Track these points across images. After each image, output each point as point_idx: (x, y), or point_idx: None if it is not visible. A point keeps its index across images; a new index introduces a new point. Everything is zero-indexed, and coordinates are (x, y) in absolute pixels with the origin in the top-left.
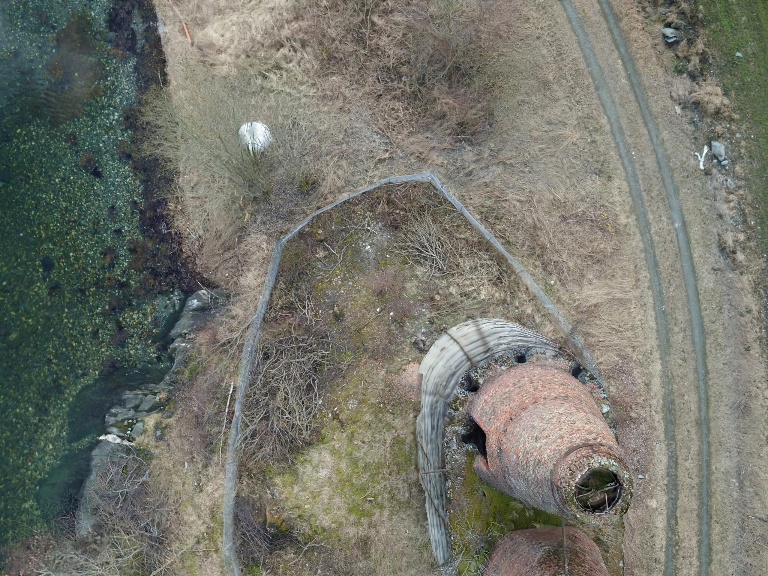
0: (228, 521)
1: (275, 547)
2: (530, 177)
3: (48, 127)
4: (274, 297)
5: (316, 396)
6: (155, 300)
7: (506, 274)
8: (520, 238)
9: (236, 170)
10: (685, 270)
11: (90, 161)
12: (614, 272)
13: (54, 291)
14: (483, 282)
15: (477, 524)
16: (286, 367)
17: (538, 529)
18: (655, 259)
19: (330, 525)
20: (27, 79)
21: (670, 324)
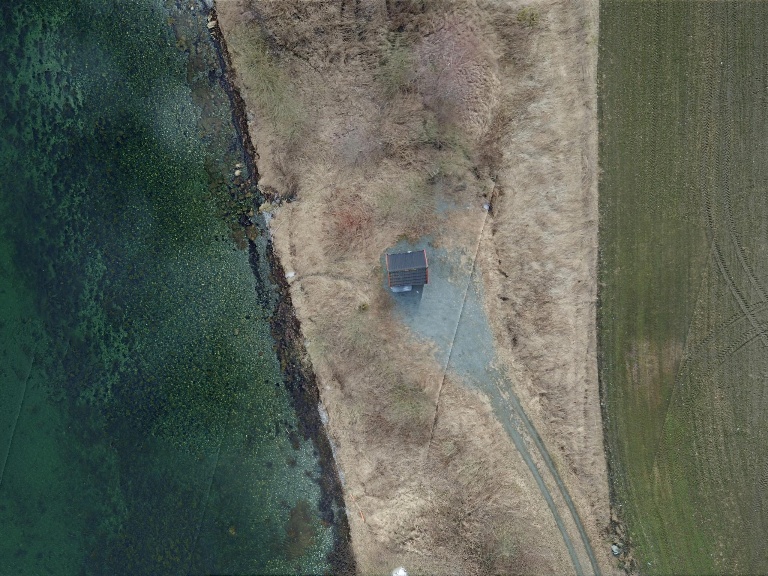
0: None
1: None
2: None
3: (285, 560)
4: None
5: None
6: None
7: None
8: None
9: None
10: None
11: None
12: None
13: None
14: None
15: None
16: None
17: None
18: None
19: None
20: (274, 533)
21: None
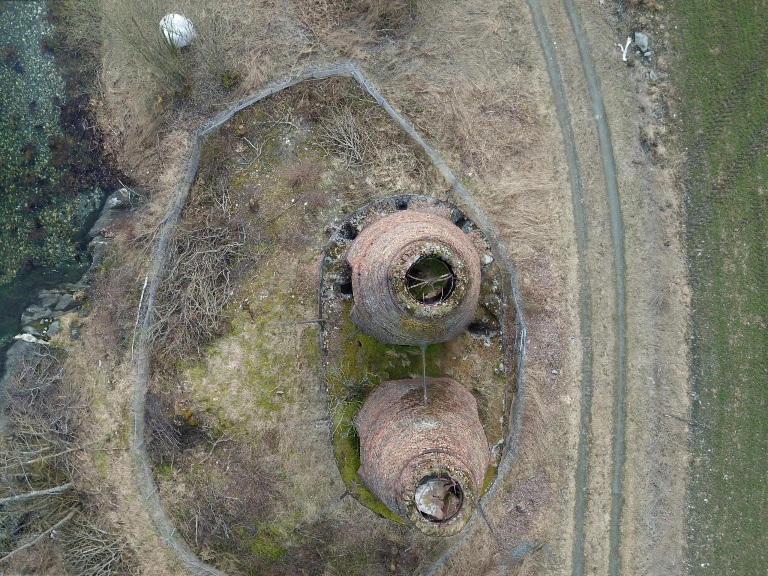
0: (140, 419)
1: (186, 445)
2: (451, 68)
3: None
4: (193, 193)
5: (227, 287)
6: (75, 198)
7: (423, 165)
8: (439, 130)
9: (154, 60)
10: (605, 163)
11: (11, 55)
12: (532, 163)
13: None
14: (400, 173)
15: (352, 375)
16: (199, 259)
17: (413, 379)
18: (574, 151)
19: (238, 418)
20: None
21: (588, 217)
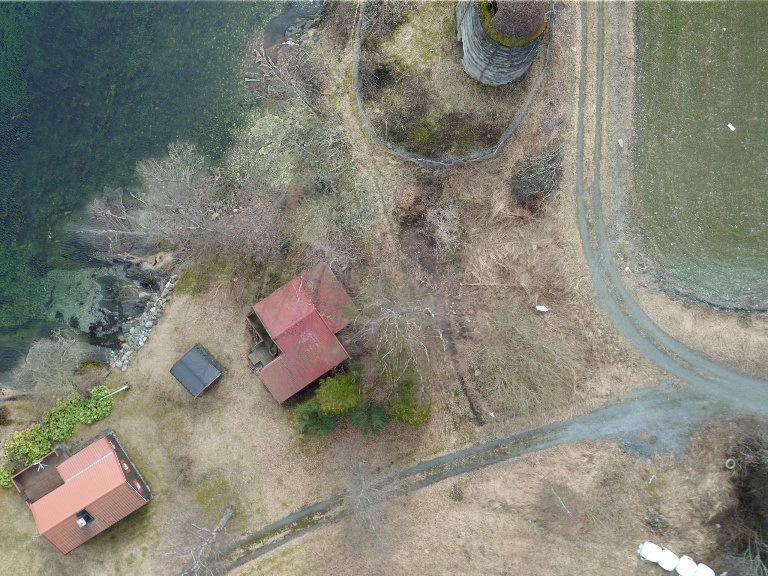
0: (355, 76)
1: (380, 87)
2: None
3: None
4: None
5: (405, 0)
6: None
7: None
8: None
9: None
10: None
11: None
12: None
13: None
14: None
15: None
16: None
17: None
18: None
19: (411, 64)
20: None
21: None
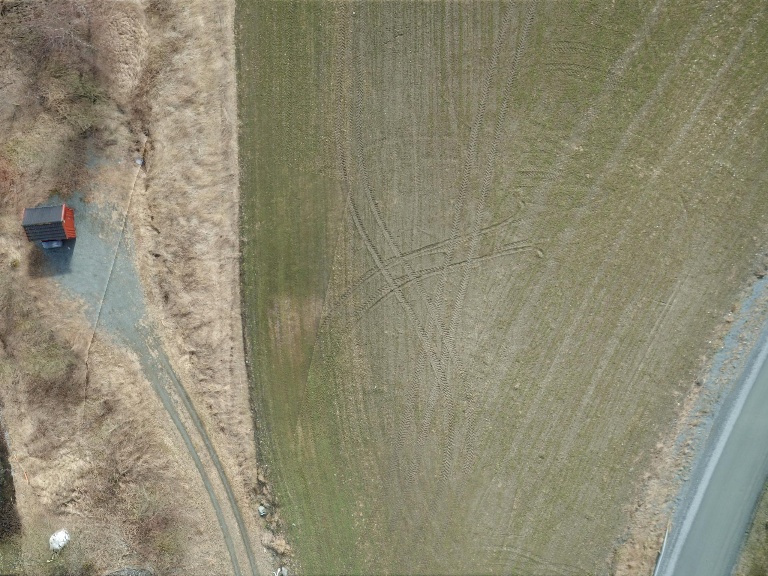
0: None
1: None
2: None
3: None
4: None
5: None
6: None
7: None
8: None
9: None
10: None
11: None
12: None
13: None
14: None
15: None
16: None
17: None
18: None
19: None
20: None
21: None
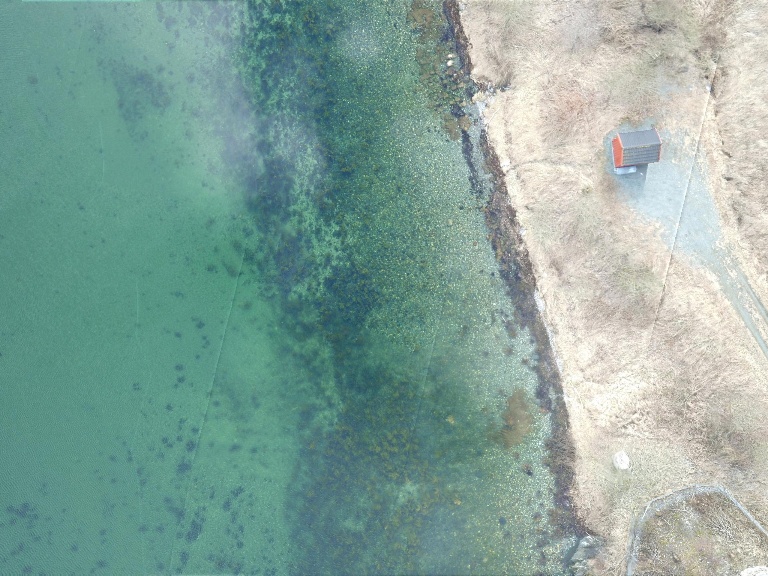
0: None
1: None
2: None
3: (503, 449)
4: (634, 544)
5: None
6: (562, 541)
7: (766, 542)
8: None
9: None
10: None
11: (528, 468)
12: None
13: (507, 536)
14: (754, 546)
15: None
16: None
17: None
18: None
19: None
20: (491, 423)
21: None
